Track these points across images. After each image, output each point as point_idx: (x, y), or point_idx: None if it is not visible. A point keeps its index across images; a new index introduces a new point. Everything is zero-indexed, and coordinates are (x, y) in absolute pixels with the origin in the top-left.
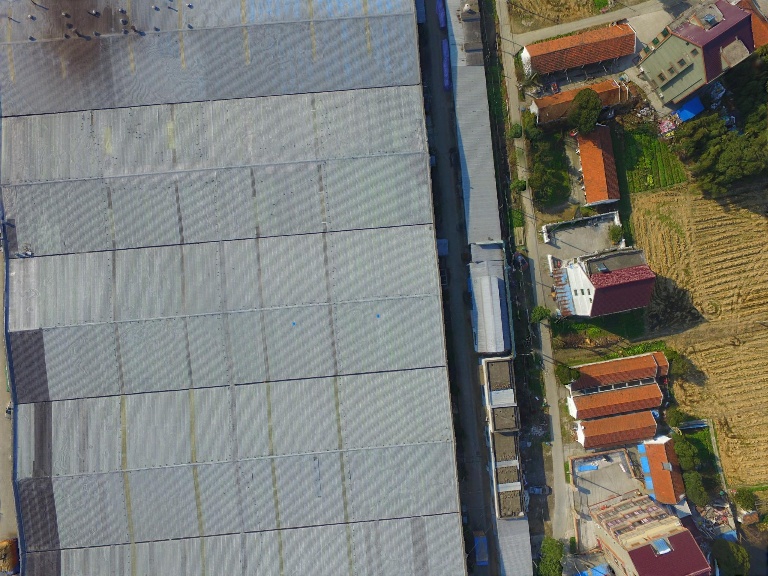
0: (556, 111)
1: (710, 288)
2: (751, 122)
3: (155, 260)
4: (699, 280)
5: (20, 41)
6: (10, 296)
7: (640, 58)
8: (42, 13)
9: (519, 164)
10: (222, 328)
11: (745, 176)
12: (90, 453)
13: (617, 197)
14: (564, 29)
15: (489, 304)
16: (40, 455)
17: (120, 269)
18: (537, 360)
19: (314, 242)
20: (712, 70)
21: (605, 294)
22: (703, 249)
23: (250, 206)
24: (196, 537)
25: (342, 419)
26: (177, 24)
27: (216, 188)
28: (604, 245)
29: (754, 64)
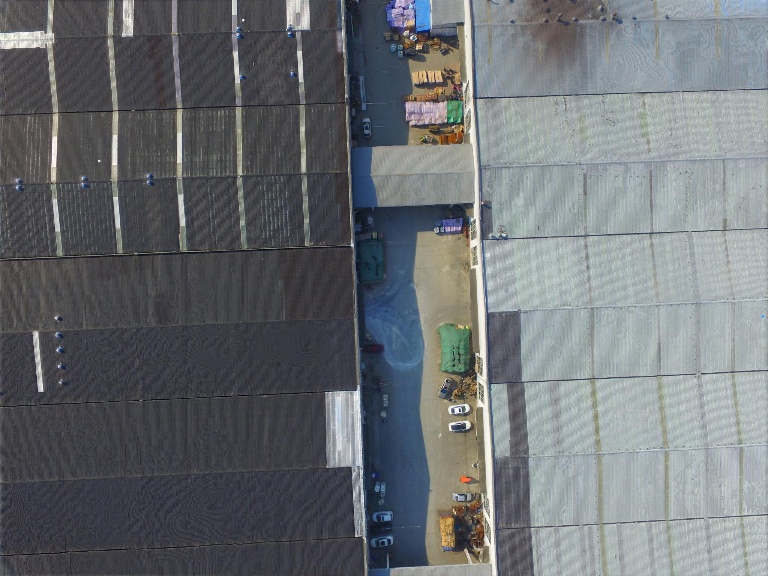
0: None
1: None
2: None
3: (626, 247)
4: None
5: (500, 23)
6: (487, 277)
7: None
8: None
9: None
10: (694, 317)
11: None
12: (564, 435)
13: None
14: None
15: None
16: (515, 435)
17: (593, 255)
18: None
19: None
20: None
21: None
22: None
23: (719, 198)
24: (661, 520)
25: None
26: (653, 13)
27: (689, 179)
28: None
29: None
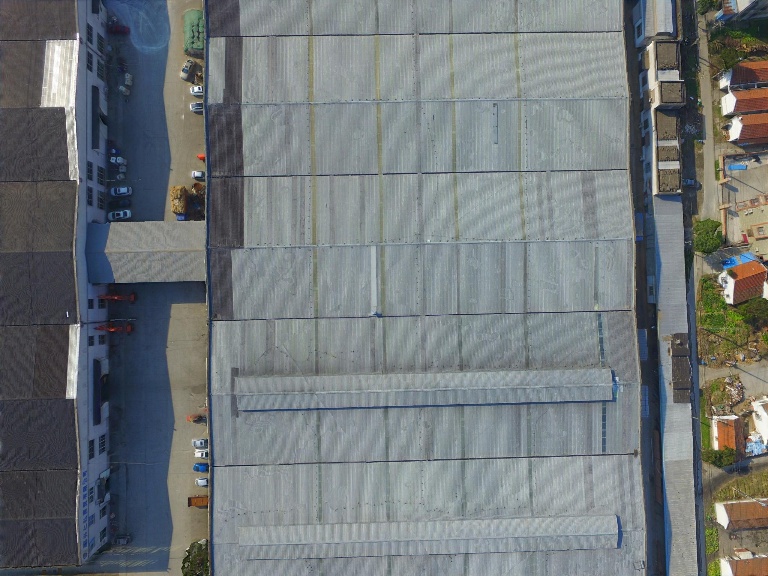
0: None
1: None
2: None
3: None
4: None
5: None
6: None
7: None
8: None
9: None
10: None
11: None
12: (278, 85)
13: None
14: None
15: None
16: (230, 84)
17: None
18: (693, 62)
19: None
20: None
21: None
22: None
23: None
24: (375, 174)
25: (521, 71)
26: None
27: None
28: None
29: None
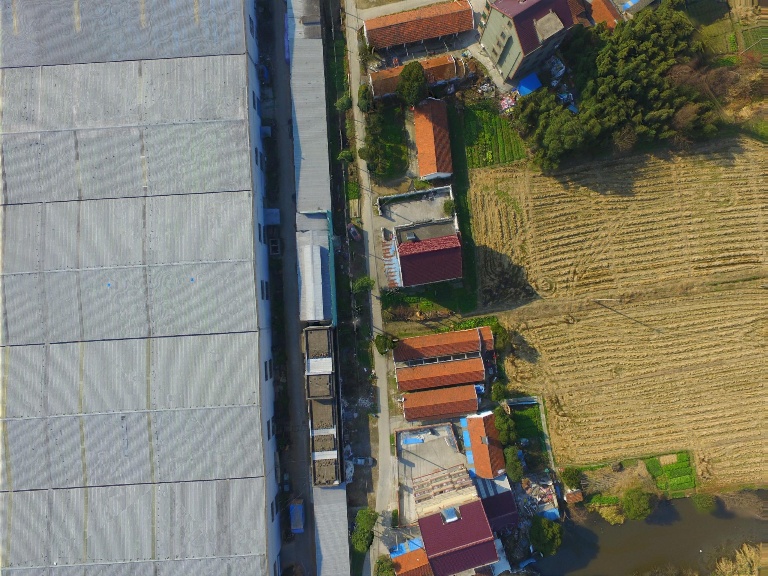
0: (391, 85)
1: (546, 265)
2: (585, 99)
3: None
4: (534, 257)
5: None
6: None
7: (479, 34)
8: None
9: (358, 137)
10: (39, 287)
11: (570, 151)
12: None
13: (449, 171)
14: (409, 5)
15: (310, 272)
16: None
17: None
18: (367, 332)
19: (134, 206)
20: (528, 43)
21: (412, 263)
22: (540, 226)
23: (73, 169)
24: (5, 492)
25: (152, 380)
26: None
27: (40, 150)
28: None
29: (588, 41)
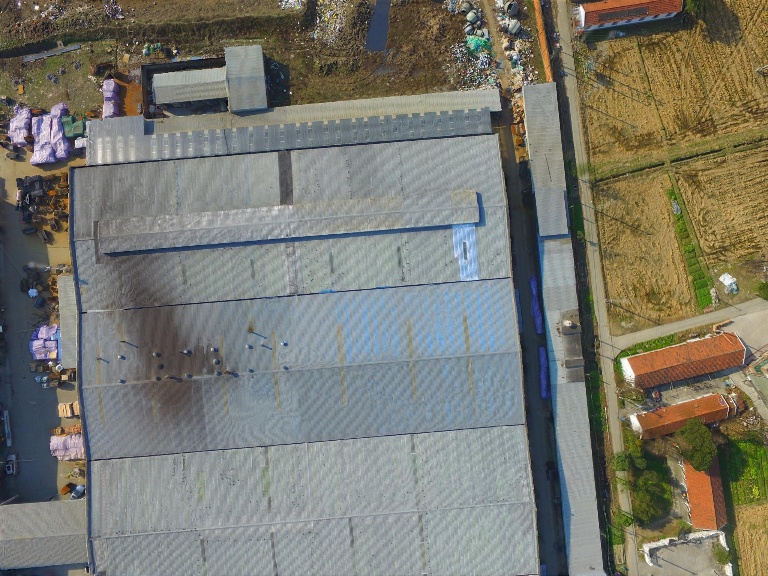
0: (660, 430)
1: None
2: None
3: None
4: None
5: (110, 384)
6: None
7: (749, 370)
8: (132, 353)
9: (618, 476)
10: None
11: None
12: None
13: (725, 522)
14: (666, 331)
15: None
16: None
17: None
18: None
19: None
20: None
21: None
22: None
23: (348, 557)
24: None
25: None
26: (271, 364)
27: (313, 540)
28: (708, 563)
29: None
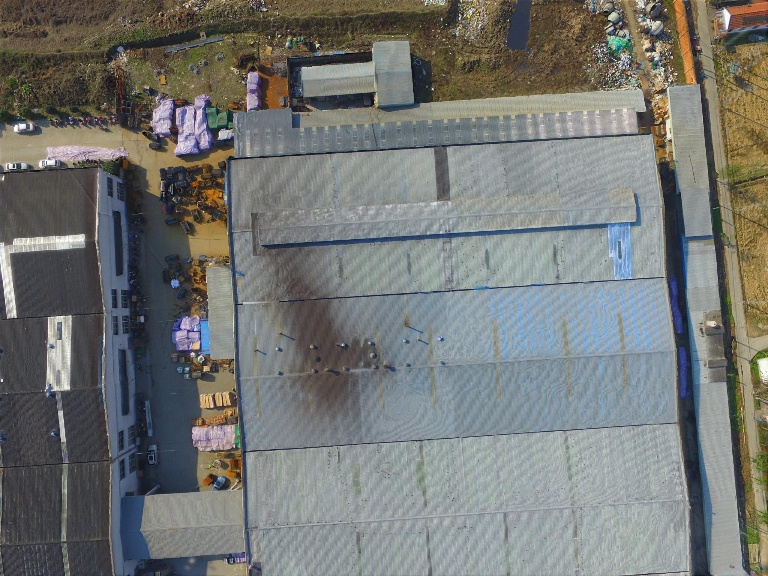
0: None
1: None
2: None
3: None
4: None
5: (267, 375)
6: None
7: None
8: (289, 345)
9: (754, 476)
10: None
11: None
12: None
13: None
14: None
15: None
16: None
17: None
18: None
19: None
20: None
21: None
22: None
23: (502, 552)
24: None
25: None
26: (428, 359)
27: (468, 534)
28: None
29: None
